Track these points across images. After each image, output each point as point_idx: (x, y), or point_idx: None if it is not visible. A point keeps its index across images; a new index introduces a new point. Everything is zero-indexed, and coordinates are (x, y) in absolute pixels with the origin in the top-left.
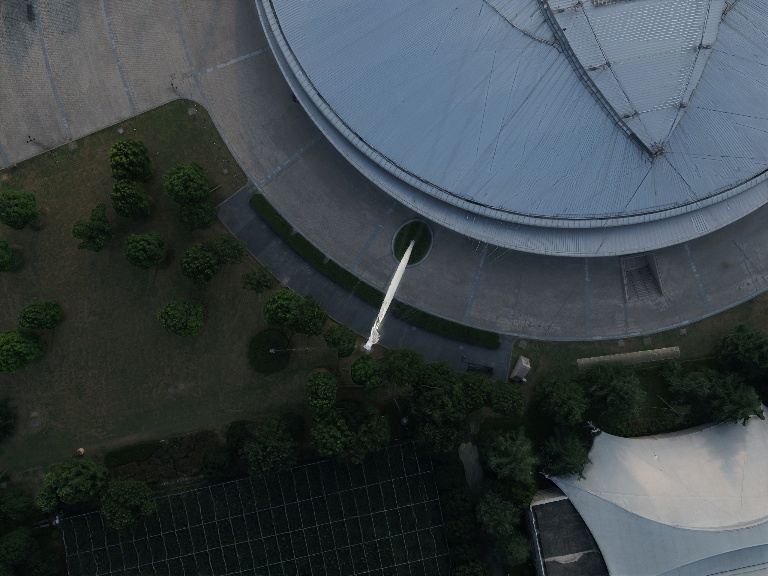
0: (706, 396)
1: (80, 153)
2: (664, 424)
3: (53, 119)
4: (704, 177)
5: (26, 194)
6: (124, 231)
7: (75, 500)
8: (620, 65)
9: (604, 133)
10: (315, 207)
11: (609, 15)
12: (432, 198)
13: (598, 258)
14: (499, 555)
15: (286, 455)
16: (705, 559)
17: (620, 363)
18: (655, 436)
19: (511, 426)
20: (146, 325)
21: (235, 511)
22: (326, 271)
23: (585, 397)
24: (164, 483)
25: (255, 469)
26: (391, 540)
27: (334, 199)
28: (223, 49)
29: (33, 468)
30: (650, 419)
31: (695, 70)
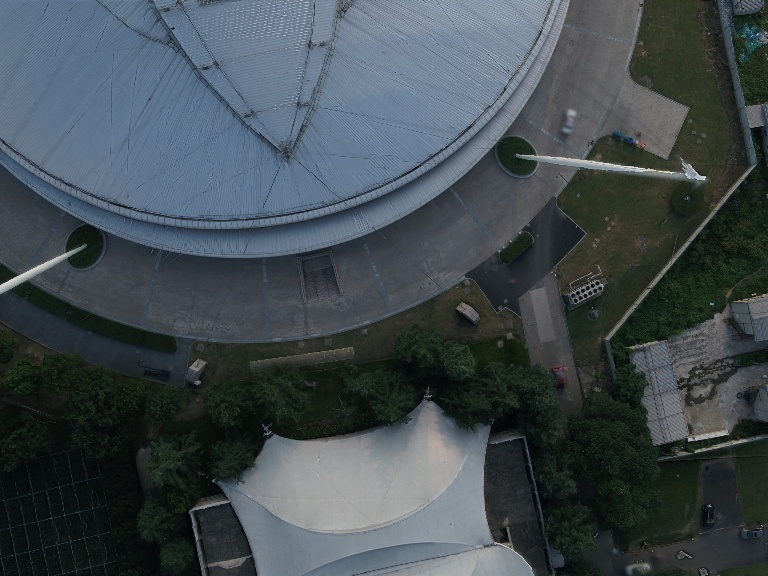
0: (369, 397)
1: None
2: (345, 425)
3: None
4: (348, 176)
5: None
6: None
7: None
8: (233, 64)
9: (242, 133)
10: None
11: (215, 14)
12: None
13: (275, 259)
14: None
15: None
16: (335, 562)
17: (285, 365)
18: (330, 438)
19: (189, 430)
20: None
21: None
22: None
23: (247, 400)
24: None
25: None
26: (58, 548)
27: (6, 203)
28: None
29: None
30: (332, 421)
31: (313, 68)
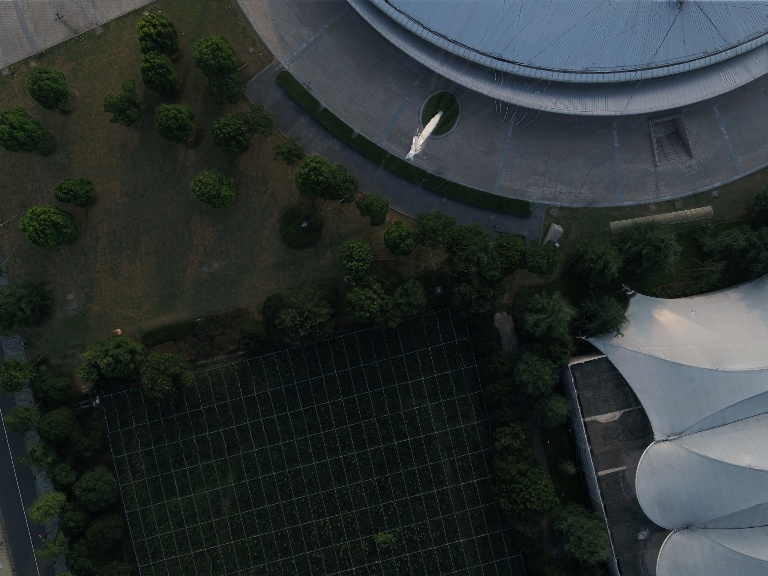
0: (741, 250)
1: (107, 37)
2: (699, 287)
3: (79, 4)
4: (733, 24)
5: (56, 71)
6: (153, 112)
7: (116, 371)
8: None
9: None
10: (341, 82)
11: None
12: (459, 62)
13: (626, 123)
14: (539, 417)
15: (323, 320)
16: (749, 399)
17: (653, 221)
18: (691, 296)
19: (545, 294)
20: (178, 204)
21: (274, 384)
22: (355, 145)
23: (620, 256)
24: (202, 361)
25: (293, 335)
26: (430, 408)
27: (360, 74)
28: None
29: (72, 350)
30: (684, 283)
31: None
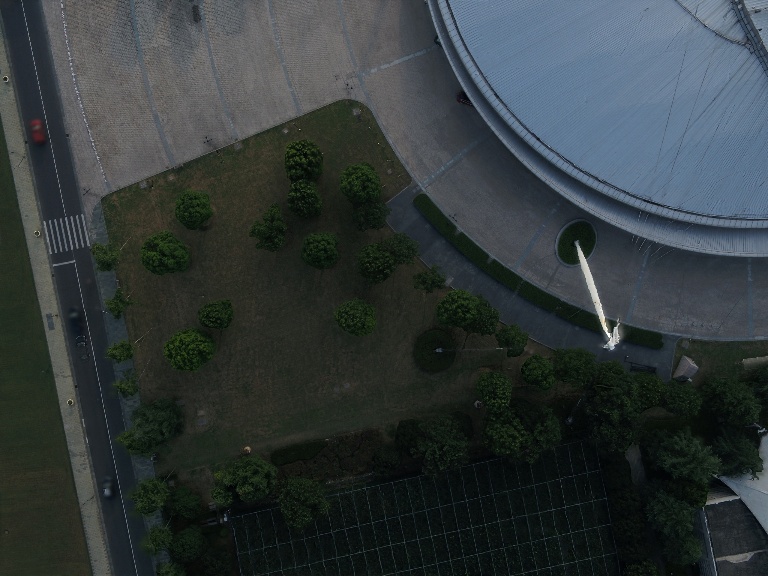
0: None
1: (246, 153)
2: None
3: (219, 119)
4: None
5: (203, 194)
6: (290, 231)
7: (254, 498)
8: None
9: None
10: (478, 207)
11: None
12: (604, 198)
13: (761, 258)
14: (669, 554)
15: (462, 454)
16: None
17: None
18: None
19: (674, 426)
20: (312, 324)
21: (403, 510)
22: (490, 271)
23: (756, 397)
24: (329, 481)
25: (431, 468)
26: (559, 539)
27: (497, 199)
28: (387, 49)
29: (200, 466)
30: None
31: None
